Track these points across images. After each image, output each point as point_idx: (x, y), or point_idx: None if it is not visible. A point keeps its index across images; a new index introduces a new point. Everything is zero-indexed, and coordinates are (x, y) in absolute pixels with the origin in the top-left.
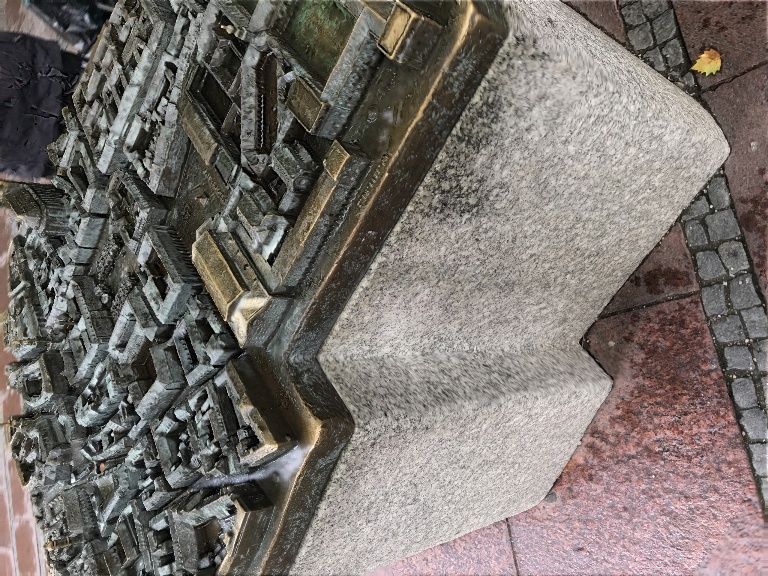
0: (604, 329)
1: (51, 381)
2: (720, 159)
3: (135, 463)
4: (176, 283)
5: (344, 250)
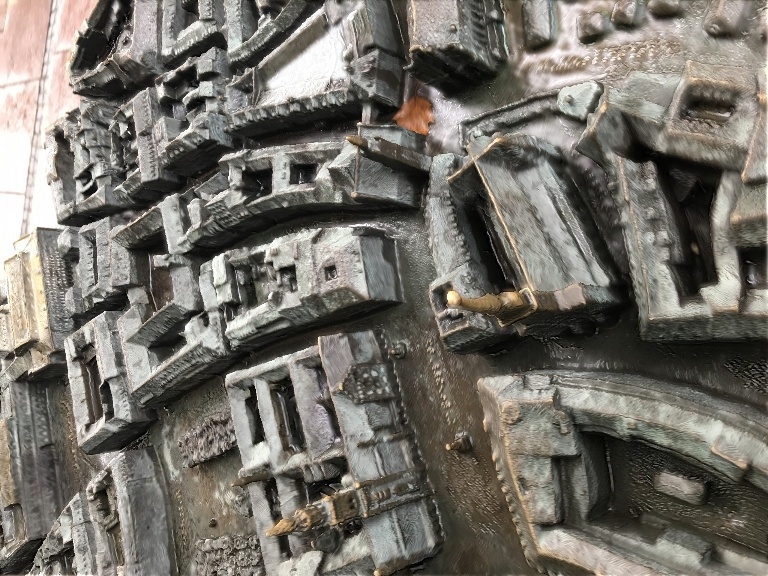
0: None
1: None
2: None
3: None
4: None
5: None
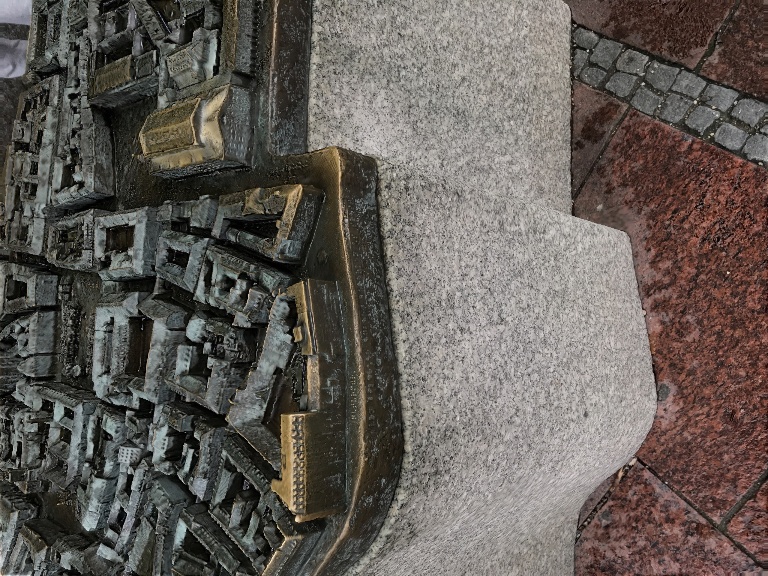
0: (585, 203)
1: (41, 537)
2: (566, 11)
3: (166, 454)
4: (139, 210)
5: (276, 7)
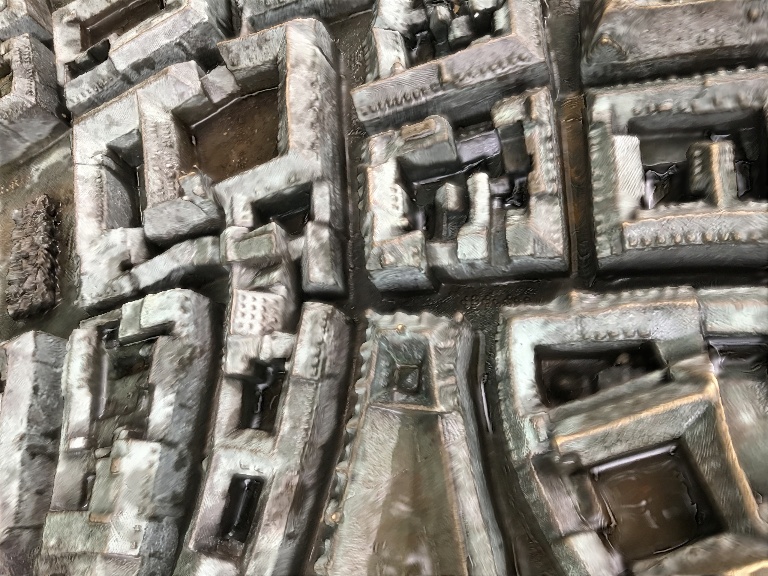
0: None
1: None
2: None
3: (405, 219)
4: None
5: None
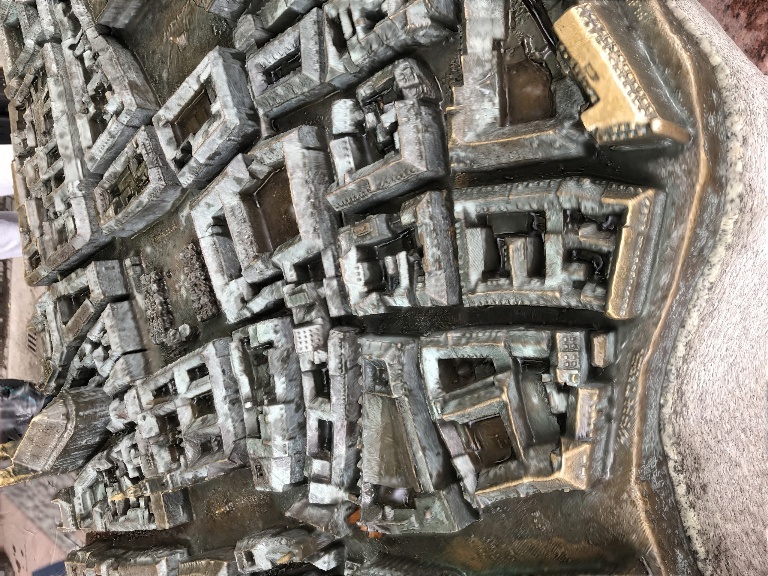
0: None
1: (212, 559)
2: None
3: (366, 286)
4: (209, 52)
5: None
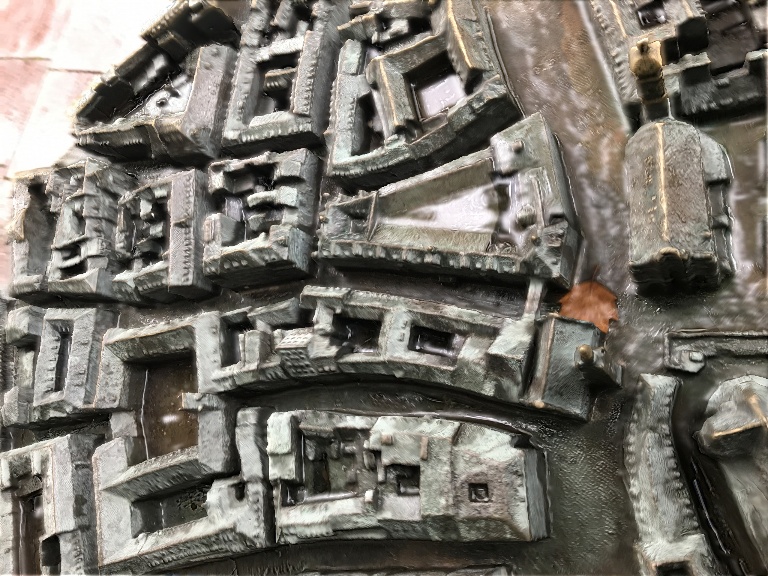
0: None
1: None
2: None
3: None
4: None
5: None
